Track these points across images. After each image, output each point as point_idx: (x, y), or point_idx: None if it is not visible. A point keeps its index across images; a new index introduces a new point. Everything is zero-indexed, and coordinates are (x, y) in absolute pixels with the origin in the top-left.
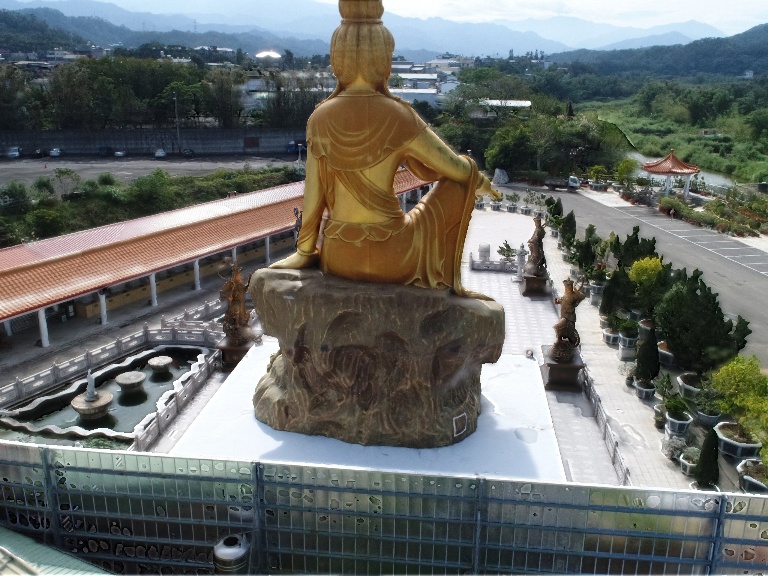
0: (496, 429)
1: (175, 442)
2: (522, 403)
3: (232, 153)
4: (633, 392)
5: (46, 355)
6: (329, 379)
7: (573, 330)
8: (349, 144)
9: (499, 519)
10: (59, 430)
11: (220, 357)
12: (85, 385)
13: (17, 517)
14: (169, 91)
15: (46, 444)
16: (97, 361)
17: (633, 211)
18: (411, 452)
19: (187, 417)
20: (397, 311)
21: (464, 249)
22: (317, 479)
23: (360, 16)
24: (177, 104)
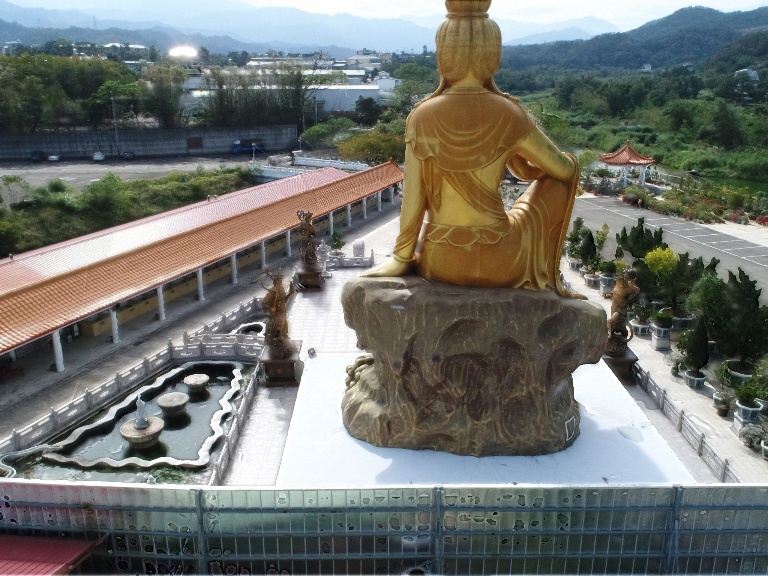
0: (599, 430)
1: (250, 466)
2: (609, 401)
3: (175, 154)
4: (682, 382)
5: (65, 380)
6: (438, 390)
7: (626, 324)
8: (461, 144)
9: (690, 526)
10: (115, 463)
11: (261, 371)
12: (121, 411)
13: (156, 568)
14: (104, 91)
15: (105, 479)
16: (126, 384)
17: (599, 202)
18: (528, 460)
19: (250, 438)
20: (515, 316)
21: None
22: (503, 500)
23: (471, 9)
24: (114, 104)
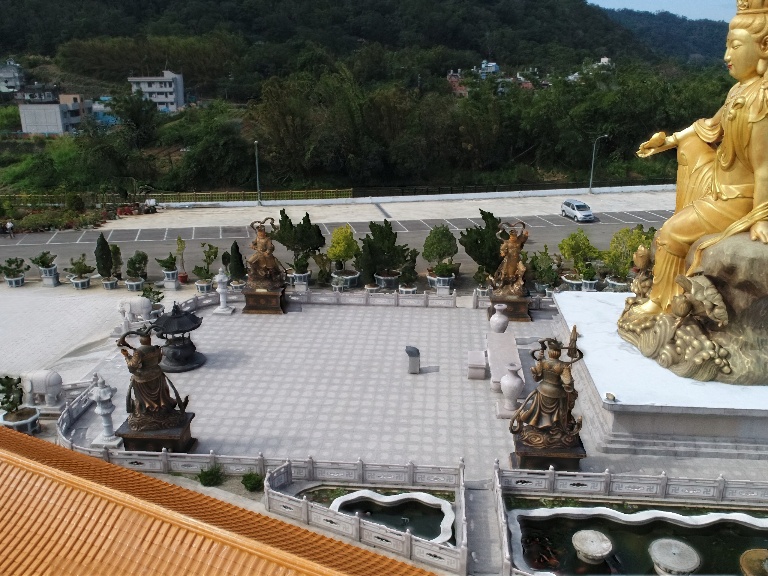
0: None
1: None
2: None
3: None
4: None
5: None
6: None
7: None
8: None
9: None
10: None
11: None
12: None
13: None
14: None
15: None
16: None
17: None
18: None
19: None
20: None
21: (29, 337)
22: None
23: None
24: None
